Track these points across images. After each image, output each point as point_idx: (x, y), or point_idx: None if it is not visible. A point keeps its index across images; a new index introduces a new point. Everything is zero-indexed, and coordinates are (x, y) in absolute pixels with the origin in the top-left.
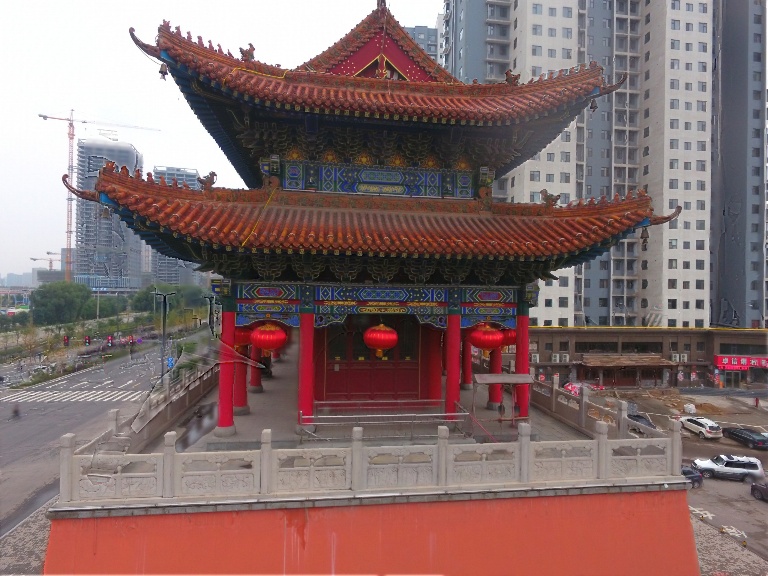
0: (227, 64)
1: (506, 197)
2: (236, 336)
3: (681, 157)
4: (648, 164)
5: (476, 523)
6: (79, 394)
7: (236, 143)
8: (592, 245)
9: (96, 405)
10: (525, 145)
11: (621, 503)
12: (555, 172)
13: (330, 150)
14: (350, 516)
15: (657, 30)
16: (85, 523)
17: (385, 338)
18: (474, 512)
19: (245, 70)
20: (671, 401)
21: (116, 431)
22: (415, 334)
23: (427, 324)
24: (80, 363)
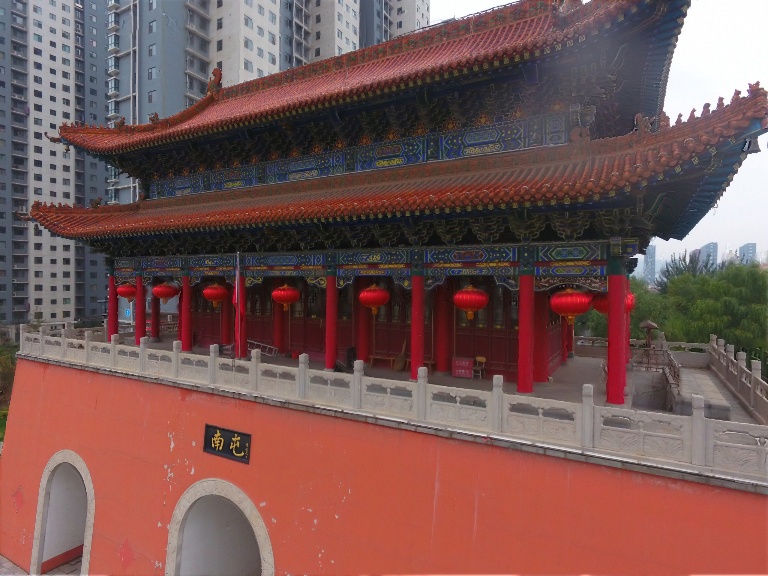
0: None
1: None
2: None
3: None
4: None
5: None
6: None
7: None
8: None
9: None
10: None
11: None
12: None
13: None
14: None
15: (327, 49)
16: None
17: None
18: None
19: None
20: None
21: None
22: None
23: None
24: None
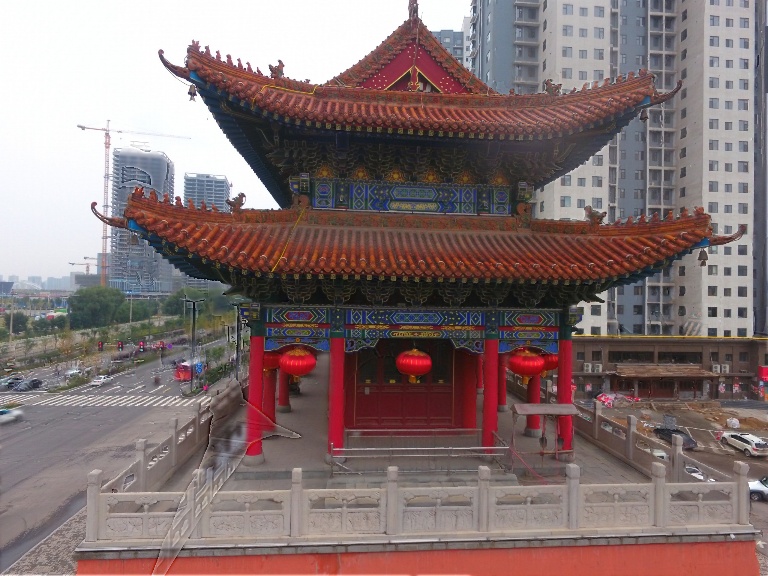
0: (257, 82)
1: (535, 202)
2: (265, 360)
3: (721, 158)
4: (685, 166)
5: (520, 573)
6: (112, 399)
7: (265, 160)
8: (644, 268)
9: (128, 410)
10: (566, 158)
11: (681, 554)
12: (587, 176)
13: (361, 167)
14: (385, 563)
15: (695, 27)
16: (111, 564)
17: (419, 364)
18: (518, 561)
19: (275, 87)
20: (712, 414)
21: (144, 462)
22: (448, 356)
23: (463, 349)
24: (113, 368)
